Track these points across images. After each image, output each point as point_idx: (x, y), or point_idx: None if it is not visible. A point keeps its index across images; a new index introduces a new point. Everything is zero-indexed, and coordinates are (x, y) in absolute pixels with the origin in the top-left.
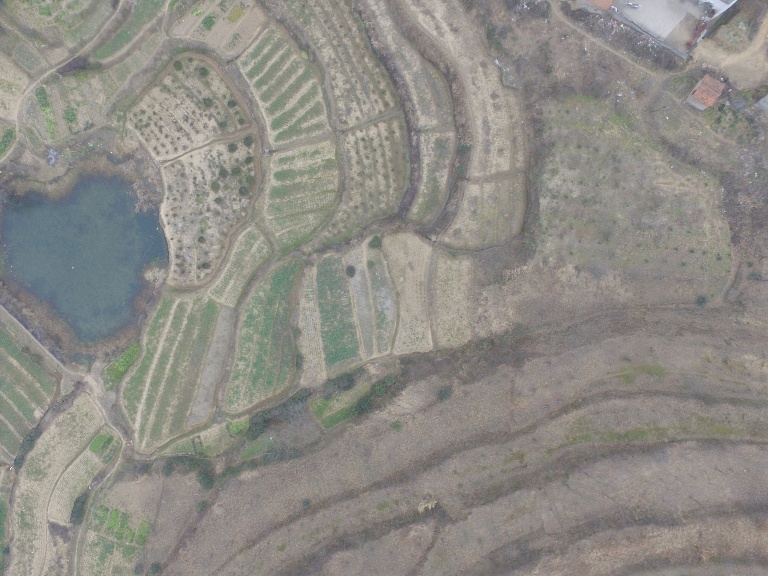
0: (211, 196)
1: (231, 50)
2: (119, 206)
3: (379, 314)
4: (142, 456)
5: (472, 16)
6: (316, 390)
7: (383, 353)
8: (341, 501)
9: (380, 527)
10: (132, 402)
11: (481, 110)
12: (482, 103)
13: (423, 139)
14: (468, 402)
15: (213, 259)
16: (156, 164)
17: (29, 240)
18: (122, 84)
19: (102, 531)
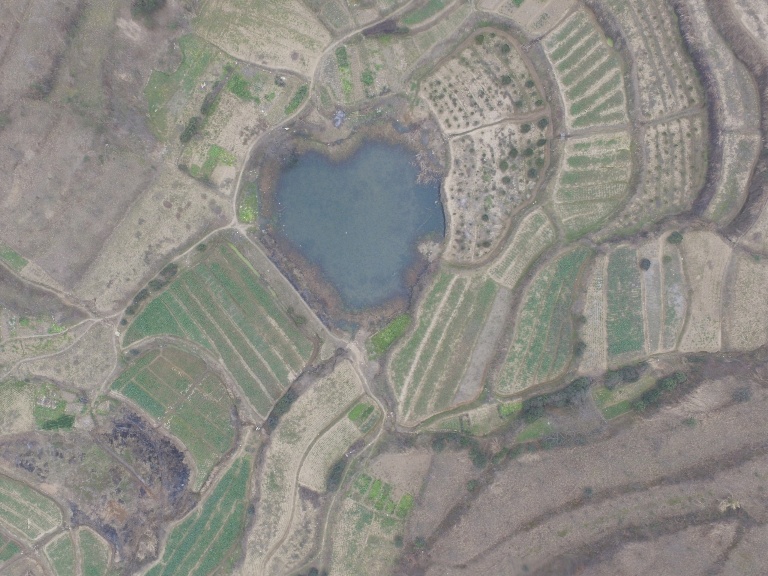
0: (497, 175)
1: (537, 30)
2: (398, 175)
3: (669, 310)
4: (405, 429)
5: None
6: (595, 380)
7: (668, 349)
8: (629, 492)
9: (673, 522)
10: (400, 374)
11: None
12: None
13: (728, 139)
14: (767, 406)
15: (493, 238)
16: (444, 137)
17: (302, 200)
18: (424, 52)
19: (362, 500)
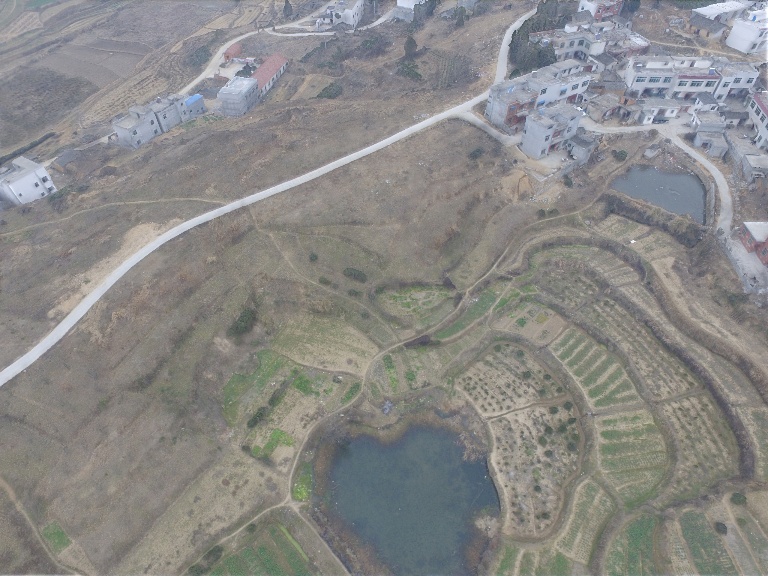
0: (539, 449)
1: (542, 340)
2: (445, 454)
3: None
4: None
5: (746, 326)
6: None
7: None
8: None
9: None
10: None
11: None
12: None
13: (740, 411)
14: None
15: (551, 510)
16: (482, 419)
17: (355, 479)
18: (455, 357)
19: None
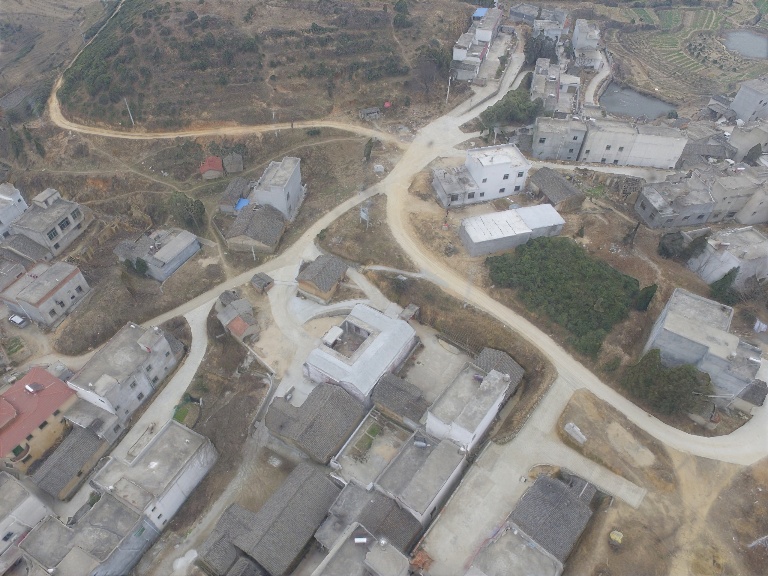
0: None
1: None
2: None
3: None
4: (710, 8)
5: None
6: (647, 7)
7: None
8: None
9: None
10: None
11: None
12: None
13: None
14: None
15: None
16: None
17: None
18: (759, 65)
19: None
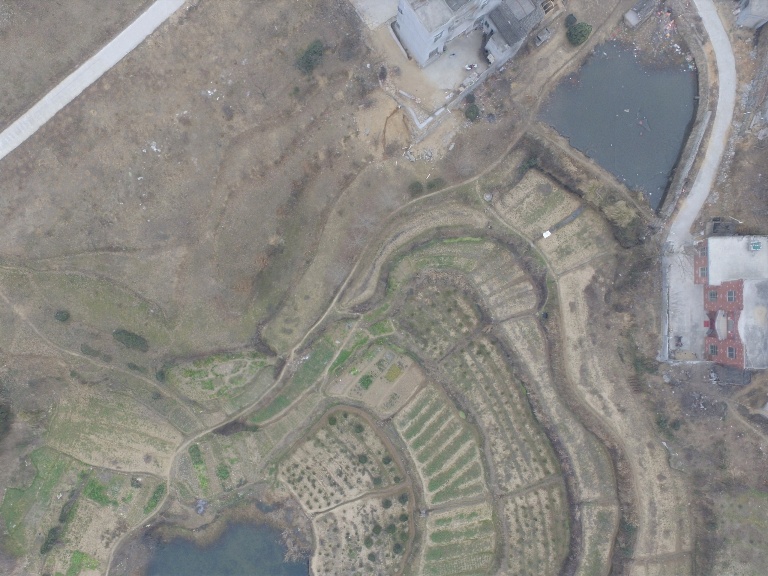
0: (363, 551)
1: (388, 410)
2: (266, 552)
3: None
4: None
5: (640, 398)
6: None
7: None
8: None
9: None
10: None
11: (648, 491)
12: (649, 484)
13: (585, 512)
14: None
15: None
16: (307, 516)
17: None
18: (277, 443)
19: None
